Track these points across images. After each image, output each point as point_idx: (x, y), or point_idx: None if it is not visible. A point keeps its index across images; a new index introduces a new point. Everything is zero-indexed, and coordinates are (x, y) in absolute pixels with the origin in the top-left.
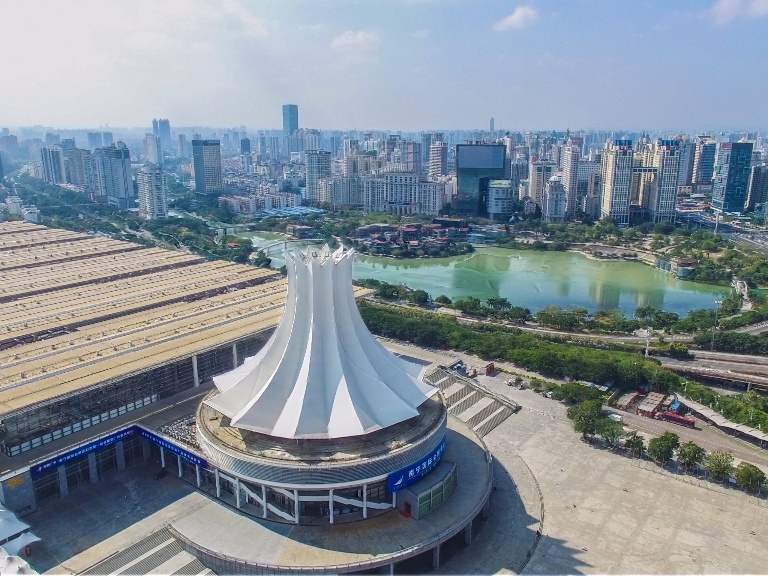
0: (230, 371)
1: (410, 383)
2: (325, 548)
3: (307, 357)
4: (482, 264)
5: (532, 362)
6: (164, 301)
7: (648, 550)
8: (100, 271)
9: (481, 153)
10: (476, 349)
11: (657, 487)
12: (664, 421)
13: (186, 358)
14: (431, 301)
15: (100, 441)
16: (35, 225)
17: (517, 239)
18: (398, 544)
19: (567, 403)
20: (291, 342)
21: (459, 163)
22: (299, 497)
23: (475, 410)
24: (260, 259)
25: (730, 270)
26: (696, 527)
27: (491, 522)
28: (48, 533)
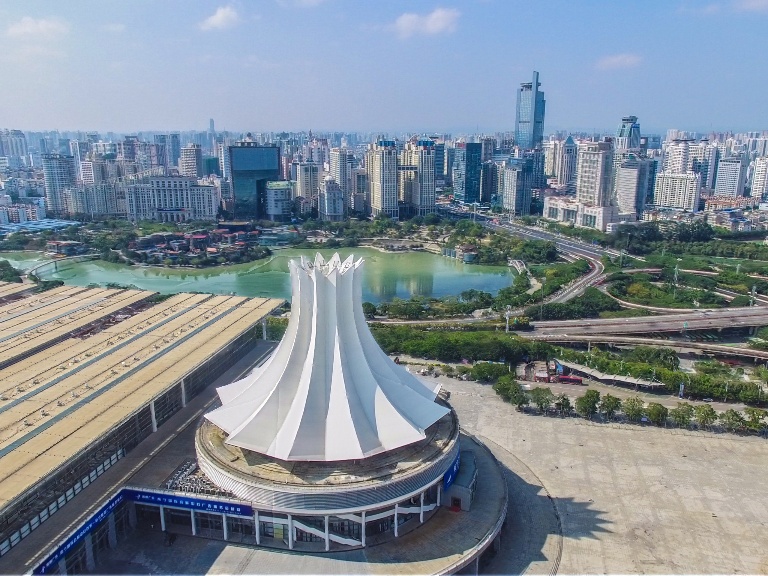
0: (225, 404)
1: (418, 383)
2: (413, 561)
3: (338, 373)
4: (266, 267)
5: (429, 351)
6: (50, 340)
7: (633, 488)
8: None
9: (255, 155)
10: None
11: (600, 437)
12: (558, 383)
13: None
14: None
15: (95, 517)
16: None
17: (309, 239)
18: (472, 537)
19: (482, 382)
20: (315, 360)
21: (234, 165)
22: (366, 518)
23: None
24: (50, 282)
25: (503, 252)
26: (648, 461)
27: None
28: None
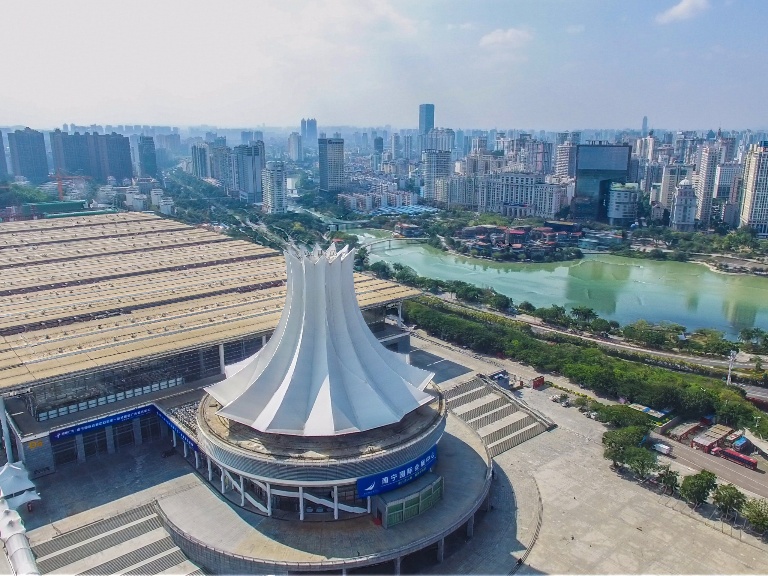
0: None
1: (404, 388)
2: (284, 543)
3: (296, 353)
4: (599, 271)
5: (587, 379)
6: (218, 291)
7: None
8: (180, 260)
9: (603, 154)
10: (531, 360)
11: (678, 530)
12: (721, 458)
13: (212, 346)
14: (510, 307)
15: (117, 416)
16: (151, 215)
17: (633, 246)
18: (356, 550)
19: (611, 426)
20: (284, 338)
21: (579, 164)
22: (271, 490)
23: (503, 423)
24: None
25: None
26: None
27: (474, 542)
28: (54, 494)
